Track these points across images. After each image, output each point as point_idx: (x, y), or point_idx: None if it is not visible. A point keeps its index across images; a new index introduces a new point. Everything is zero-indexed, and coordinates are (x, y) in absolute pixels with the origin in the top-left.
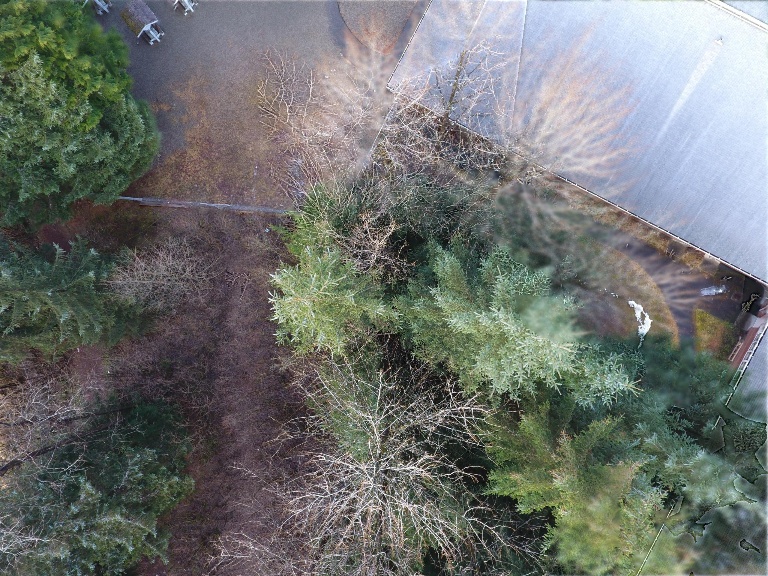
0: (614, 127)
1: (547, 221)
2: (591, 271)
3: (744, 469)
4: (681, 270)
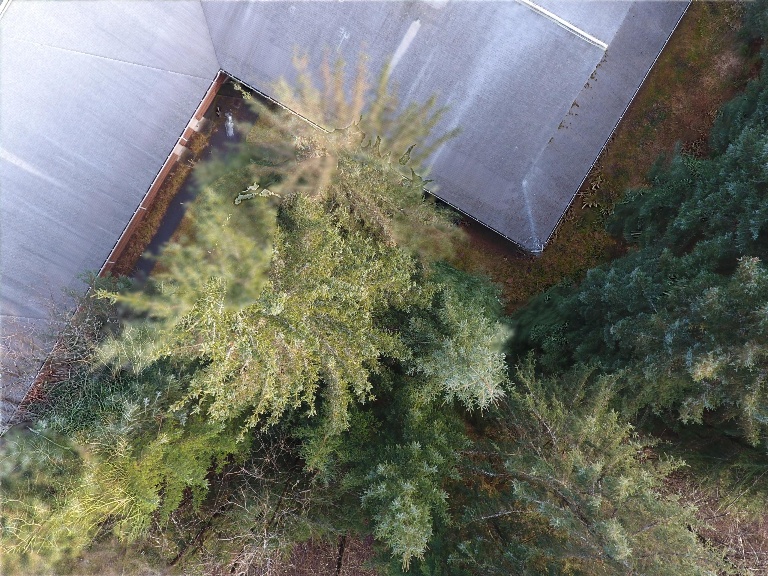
0: (48, 226)
1: (154, 278)
2: (205, 238)
3: (352, 142)
4: (208, 154)
